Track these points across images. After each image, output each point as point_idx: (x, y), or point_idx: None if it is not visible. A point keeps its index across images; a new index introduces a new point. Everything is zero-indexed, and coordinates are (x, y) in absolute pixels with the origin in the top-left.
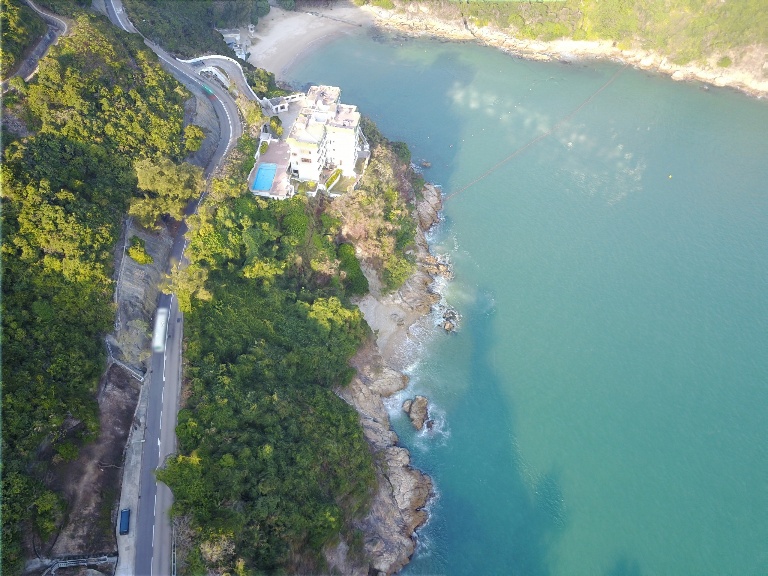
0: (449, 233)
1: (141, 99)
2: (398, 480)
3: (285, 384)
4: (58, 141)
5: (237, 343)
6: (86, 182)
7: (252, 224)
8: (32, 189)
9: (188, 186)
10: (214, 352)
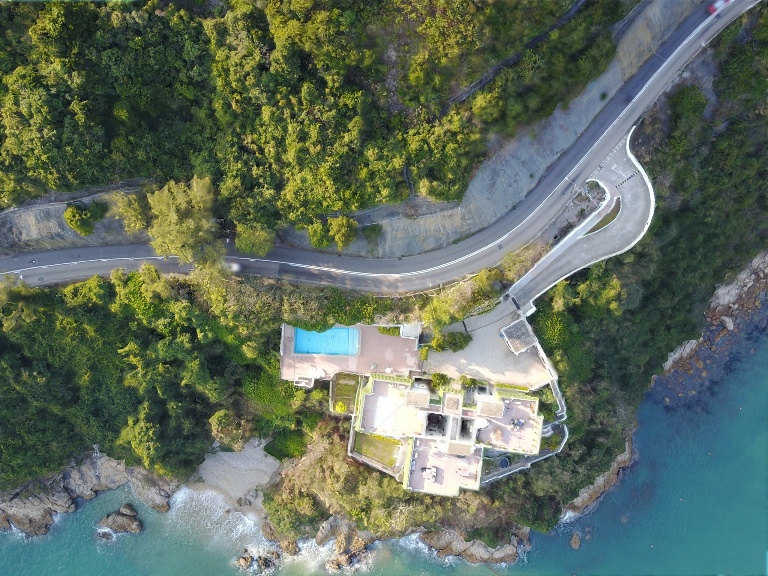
0: (416, 571)
1: (357, 139)
2: (19, 507)
3: (15, 406)
4: (197, 53)
5: (31, 351)
6: (139, 121)
7: (188, 348)
8: (59, 66)
9: (199, 256)
10: (1, 331)
